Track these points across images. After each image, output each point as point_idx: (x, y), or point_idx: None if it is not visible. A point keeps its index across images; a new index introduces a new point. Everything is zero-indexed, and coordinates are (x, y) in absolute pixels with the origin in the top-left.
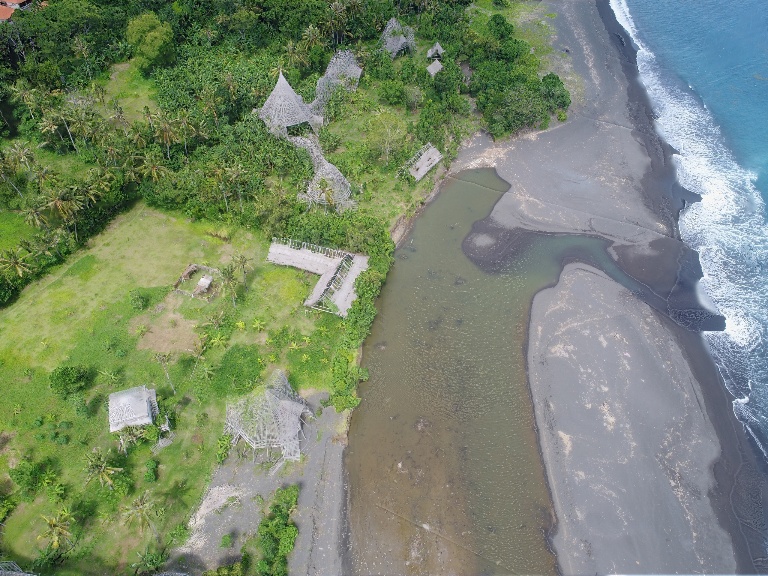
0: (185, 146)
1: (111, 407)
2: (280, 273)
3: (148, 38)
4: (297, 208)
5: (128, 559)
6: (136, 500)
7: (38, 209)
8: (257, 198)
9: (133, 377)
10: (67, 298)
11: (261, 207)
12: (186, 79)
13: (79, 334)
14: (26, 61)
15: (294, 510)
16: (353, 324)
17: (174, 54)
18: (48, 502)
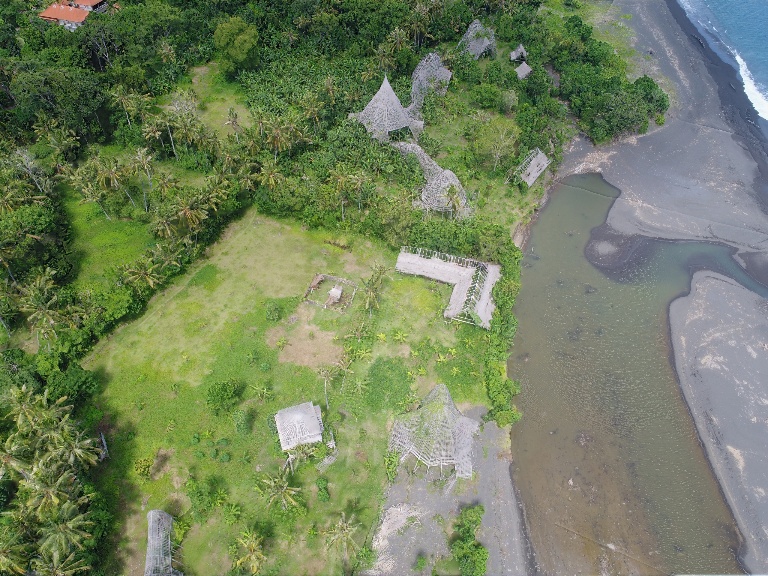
0: (289, 152)
1: (283, 425)
2: (409, 283)
3: (238, 41)
4: (414, 215)
5: None
6: (342, 524)
7: (169, 219)
8: (374, 205)
9: (282, 391)
10: (197, 309)
11: (388, 215)
12: (272, 83)
13: (217, 347)
14: (113, 65)
15: (477, 530)
16: (498, 336)
17: (258, 57)
18: (222, 523)
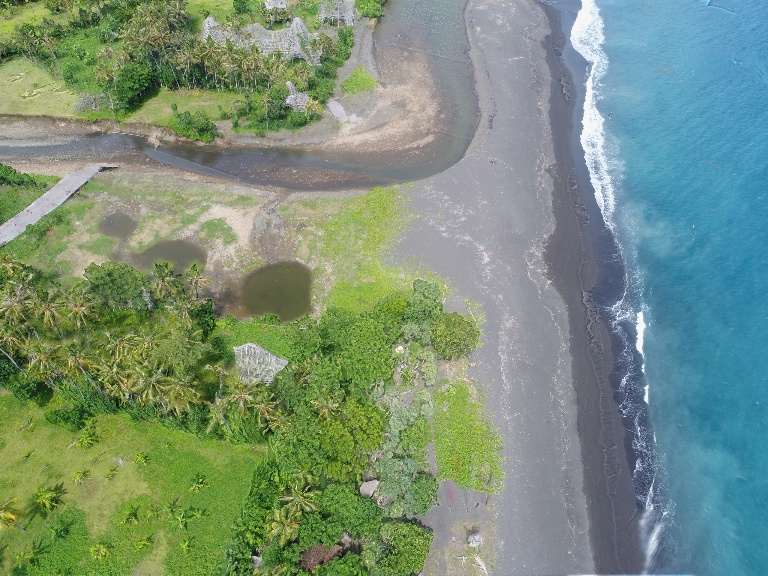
0: None
1: None
2: None
3: None
4: None
5: None
6: None
7: None
8: None
9: None
10: None
11: None
12: None
13: None
14: None
15: None
16: None
17: None
18: None
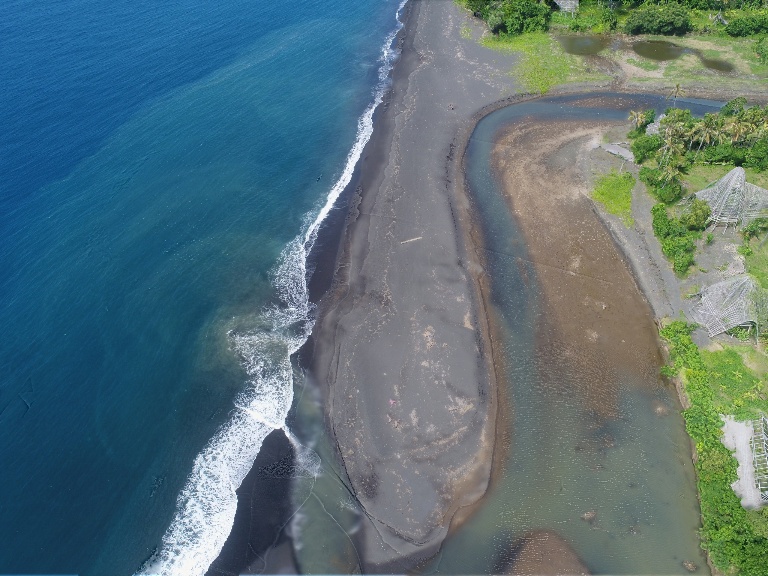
0: None
1: None
2: None
3: None
4: None
5: None
6: None
7: None
8: None
9: None
10: None
11: None
12: None
13: None
14: None
15: None
16: None
17: None
18: None
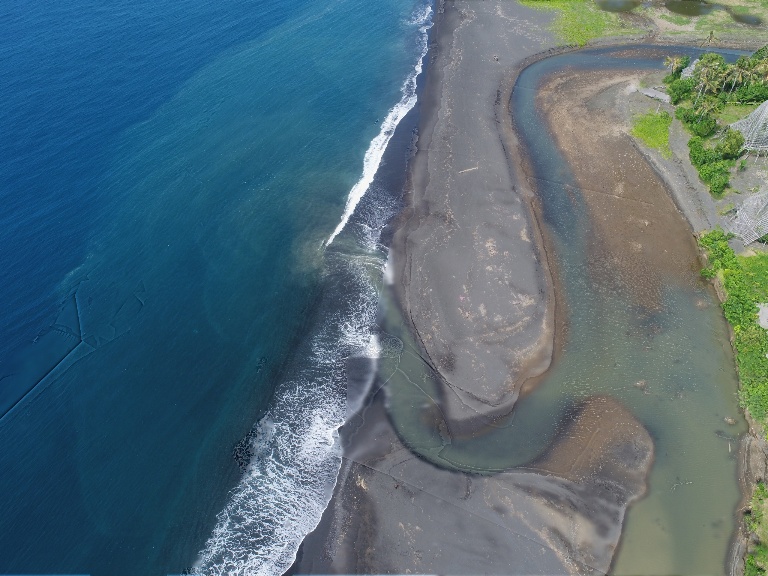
0: None
1: None
2: None
3: None
4: None
5: None
6: None
7: None
8: None
9: None
10: None
11: None
12: None
13: None
14: None
15: None
16: None
17: None
18: None
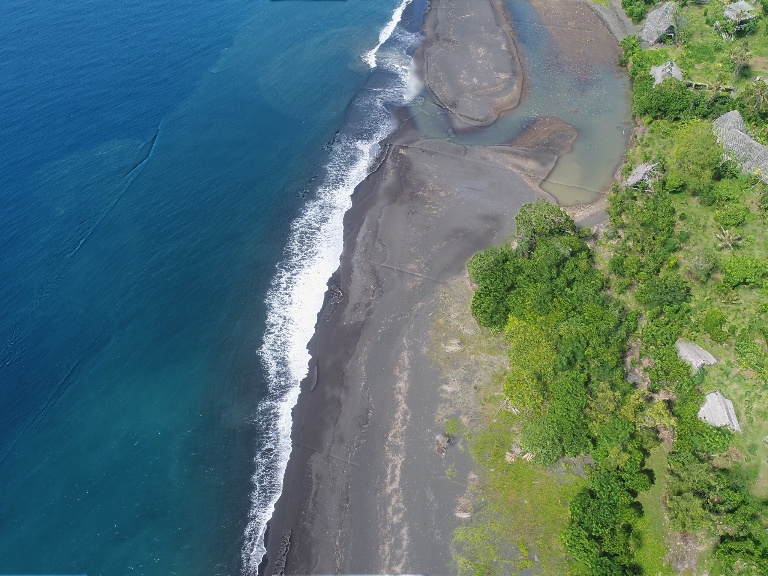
0: None
1: None
2: None
3: None
4: None
5: (695, 8)
6: None
7: None
8: None
9: (762, 48)
10: None
11: None
12: None
13: None
14: None
15: None
16: None
17: None
18: None
